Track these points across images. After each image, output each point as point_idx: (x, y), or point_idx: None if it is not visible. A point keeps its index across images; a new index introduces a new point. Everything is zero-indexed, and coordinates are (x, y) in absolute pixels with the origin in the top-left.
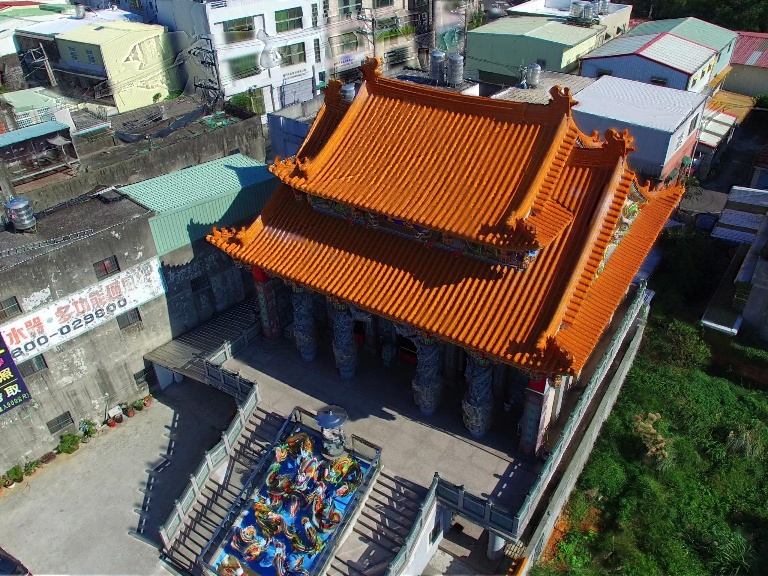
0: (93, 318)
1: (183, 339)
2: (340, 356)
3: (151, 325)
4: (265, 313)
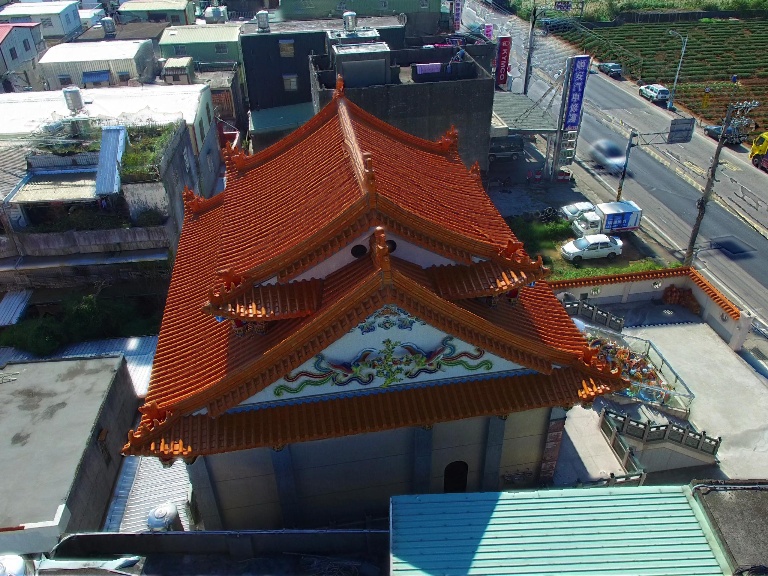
0: None
1: None
2: None
3: None
4: None
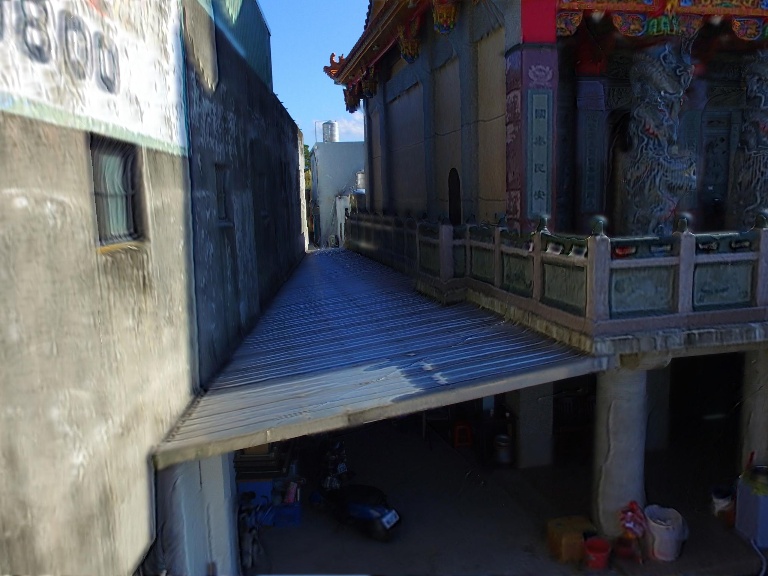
0: (2, 23)
1: (244, 377)
2: None
3: (163, 285)
4: (543, 164)
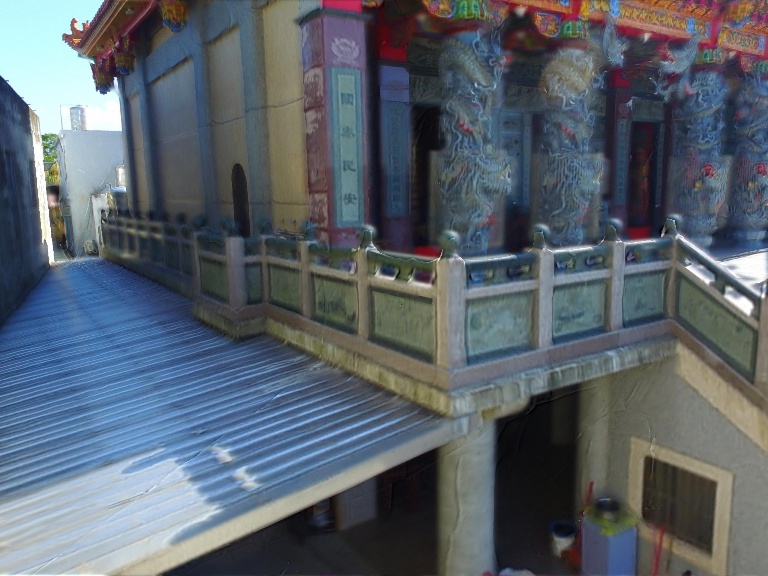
0: None
1: None
2: (589, 189)
3: None
4: (352, 161)
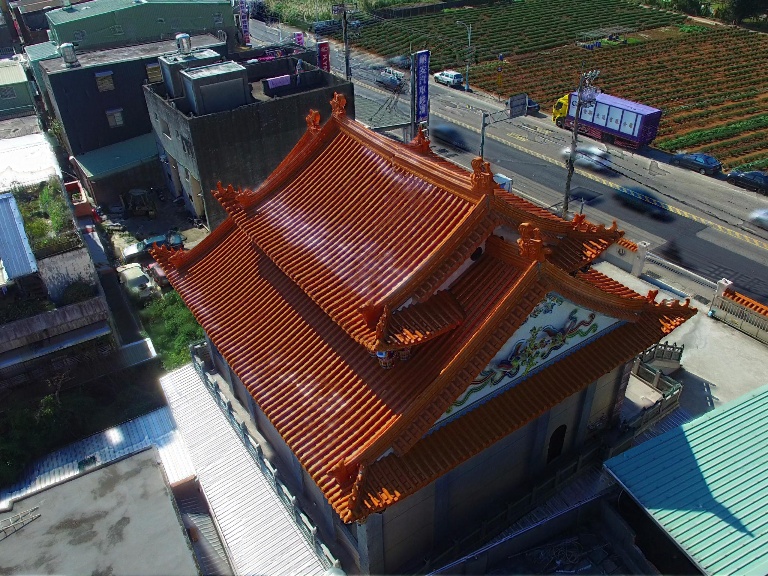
0: None
1: None
2: None
3: None
4: None
